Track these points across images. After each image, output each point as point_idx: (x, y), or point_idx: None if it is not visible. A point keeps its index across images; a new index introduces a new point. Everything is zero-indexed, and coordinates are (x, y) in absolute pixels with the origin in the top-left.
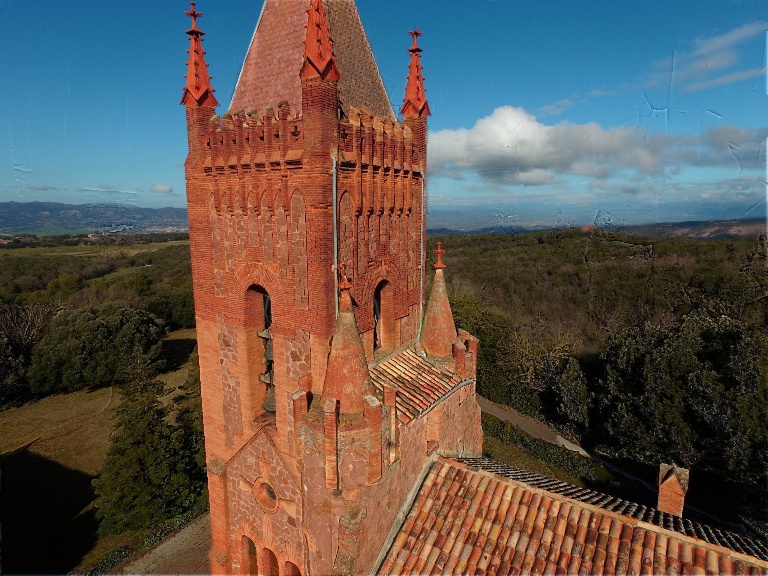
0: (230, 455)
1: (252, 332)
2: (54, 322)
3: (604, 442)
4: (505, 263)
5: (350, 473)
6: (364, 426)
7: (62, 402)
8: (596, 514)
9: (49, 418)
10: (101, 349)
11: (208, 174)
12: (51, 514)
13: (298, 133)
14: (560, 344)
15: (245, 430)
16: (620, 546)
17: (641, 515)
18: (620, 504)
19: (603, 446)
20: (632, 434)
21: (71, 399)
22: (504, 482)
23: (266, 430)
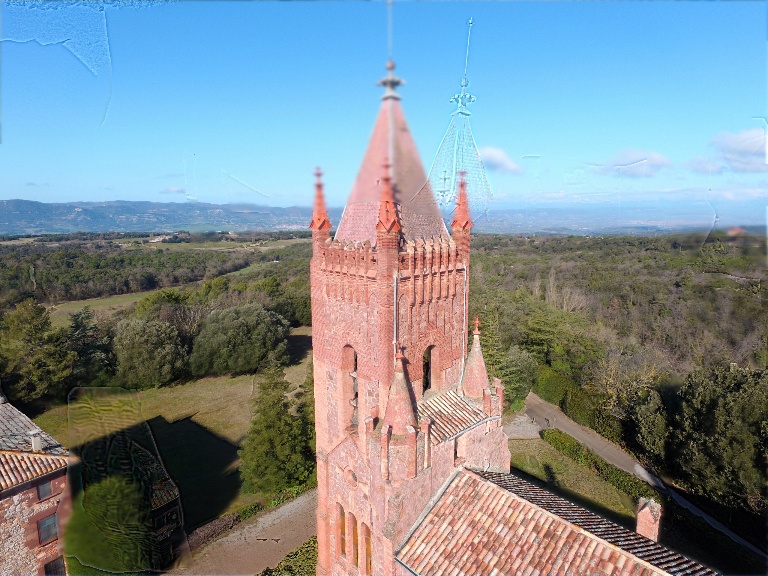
0: (331, 449)
1: (346, 373)
2: (209, 319)
3: (681, 477)
4: (604, 285)
5: (396, 471)
6: (405, 444)
7: (213, 384)
8: (556, 521)
9: (204, 396)
10: (242, 344)
11: (323, 272)
12: (208, 471)
13: (375, 261)
14: (645, 375)
15: (340, 434)
16: (565, 543)
17: (600, 529)
18: (597, 521)
19: (680, 480)
20: (704, 473)
21: (219, 382)
22: (502, 492)
23: (352, 436)
